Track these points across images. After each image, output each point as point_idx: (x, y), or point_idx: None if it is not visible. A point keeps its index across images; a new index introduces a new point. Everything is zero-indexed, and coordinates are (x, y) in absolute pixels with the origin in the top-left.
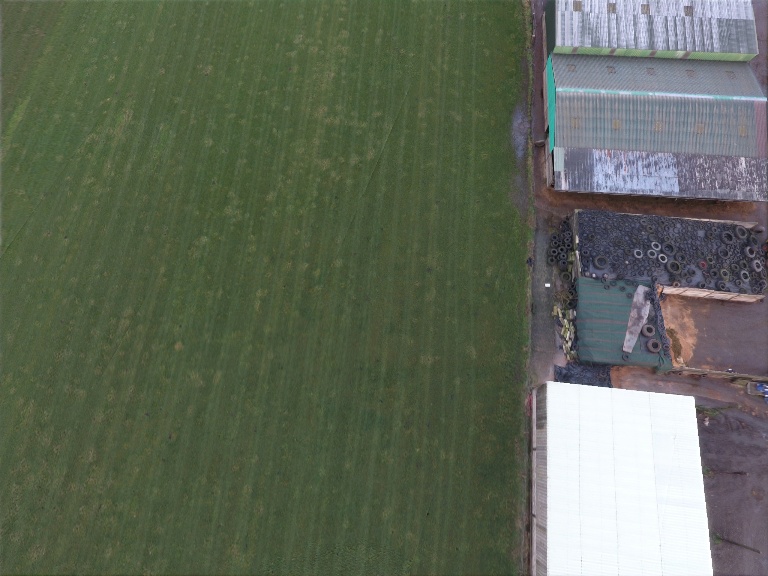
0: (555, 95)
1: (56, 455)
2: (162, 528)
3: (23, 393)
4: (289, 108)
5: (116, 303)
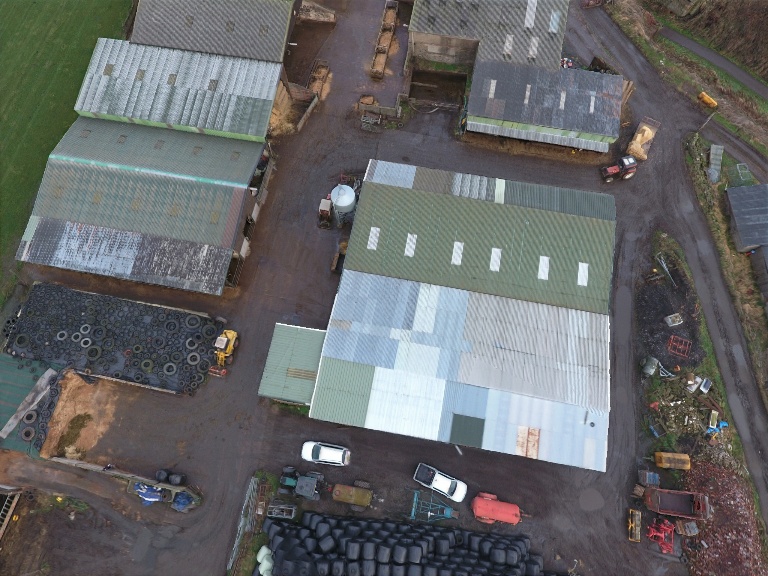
0: (47, 162)
1: None
2: None
3: None
4: None
5: None
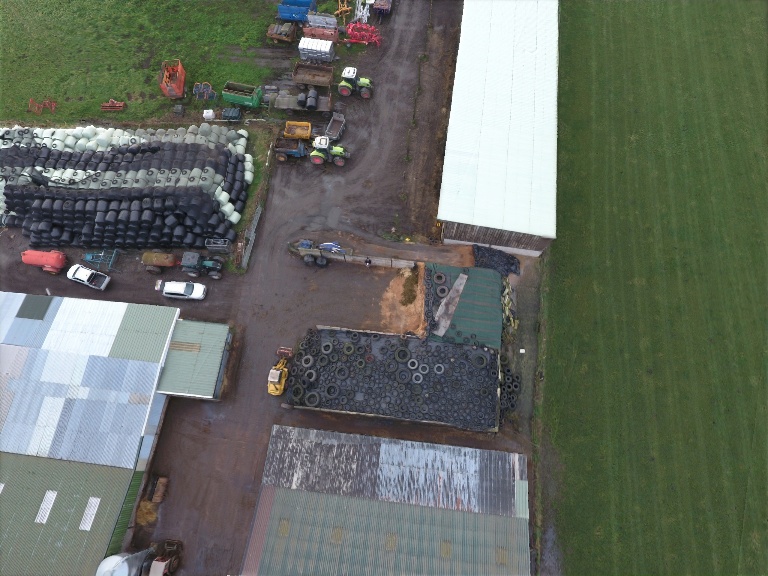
0: None
1: None
2: None
3: None
4: None
5: None
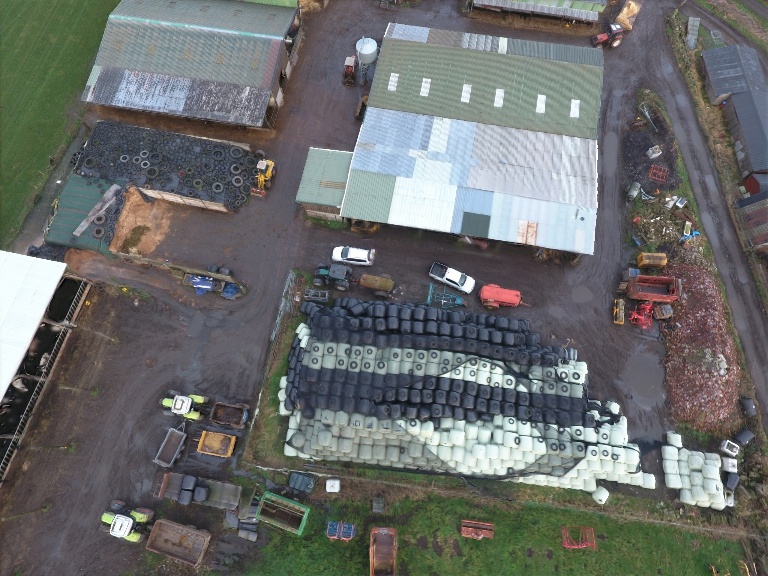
0: (107, 21)
1: None
2: None
3: None
4: None
5: None
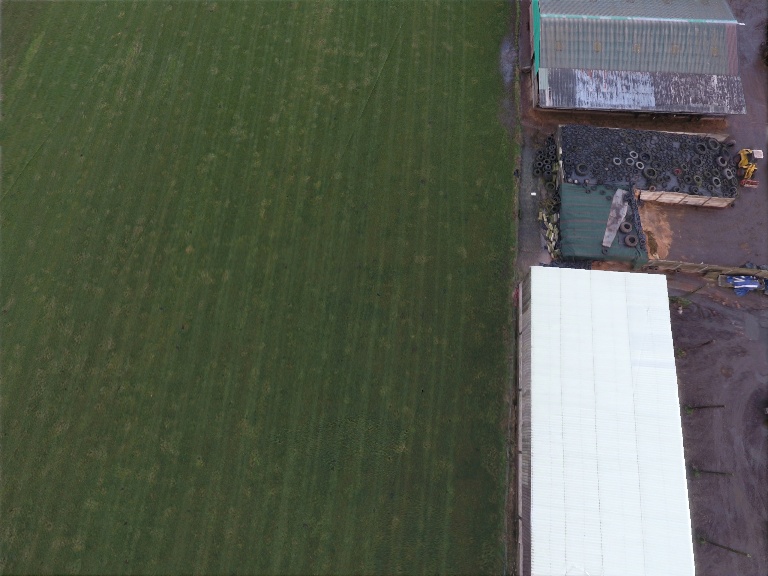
0: (540, 21)
1: (77, 344)
2: (177, 405)
3: (45, 291)
4: (290, 40)
5: (130, 212)
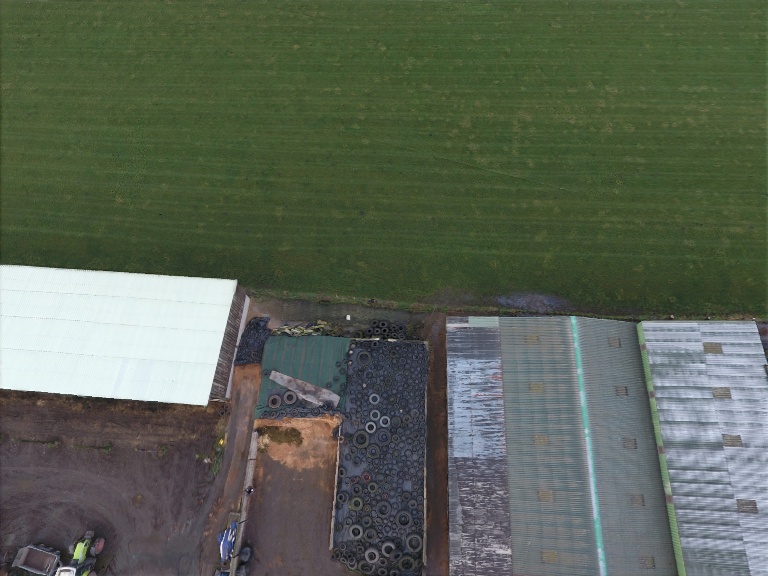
0: None
1: None
2: (174, 58)
3: None
4: (524, 90)
5: (329, 6)
